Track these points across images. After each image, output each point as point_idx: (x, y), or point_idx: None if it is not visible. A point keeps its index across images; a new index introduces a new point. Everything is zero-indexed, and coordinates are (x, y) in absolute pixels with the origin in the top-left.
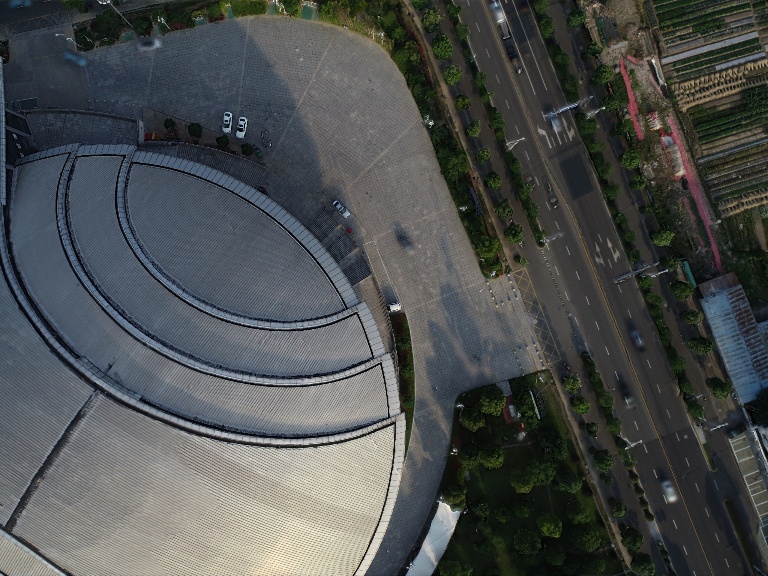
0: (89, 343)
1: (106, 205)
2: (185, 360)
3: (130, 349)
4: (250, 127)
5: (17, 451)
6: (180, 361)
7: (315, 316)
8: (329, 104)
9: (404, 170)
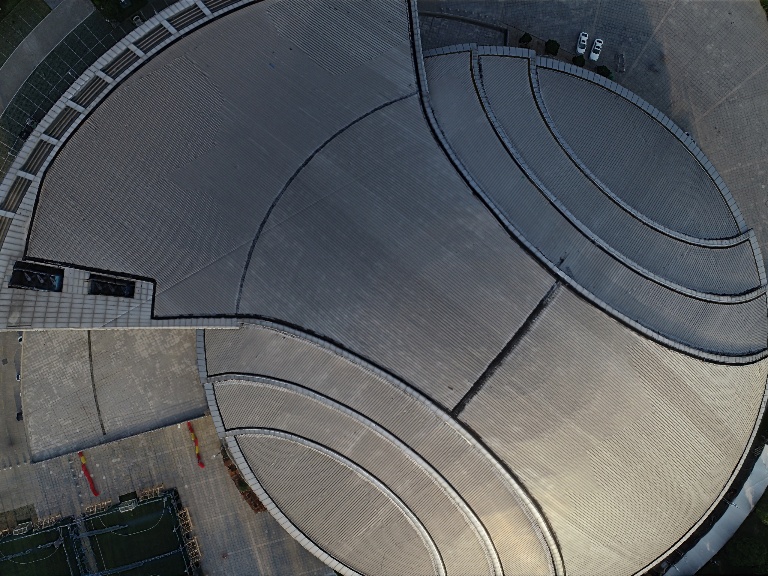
0: (541, 235)
1: (527, 104)
2: (630, 262)
3: (580, 245)
4: (603, 50)
5: (476, 335)
6: (625, 262)
7: (719, 237)
8: (686, 34)
9: (755, 108)
